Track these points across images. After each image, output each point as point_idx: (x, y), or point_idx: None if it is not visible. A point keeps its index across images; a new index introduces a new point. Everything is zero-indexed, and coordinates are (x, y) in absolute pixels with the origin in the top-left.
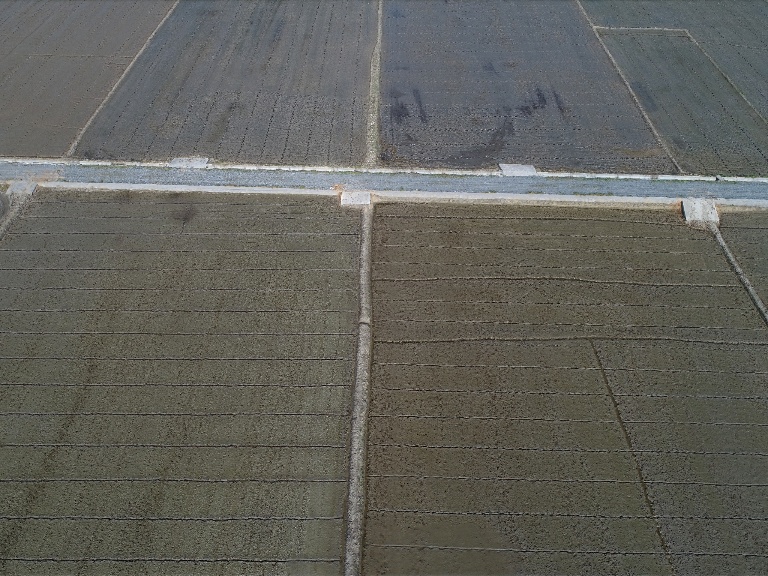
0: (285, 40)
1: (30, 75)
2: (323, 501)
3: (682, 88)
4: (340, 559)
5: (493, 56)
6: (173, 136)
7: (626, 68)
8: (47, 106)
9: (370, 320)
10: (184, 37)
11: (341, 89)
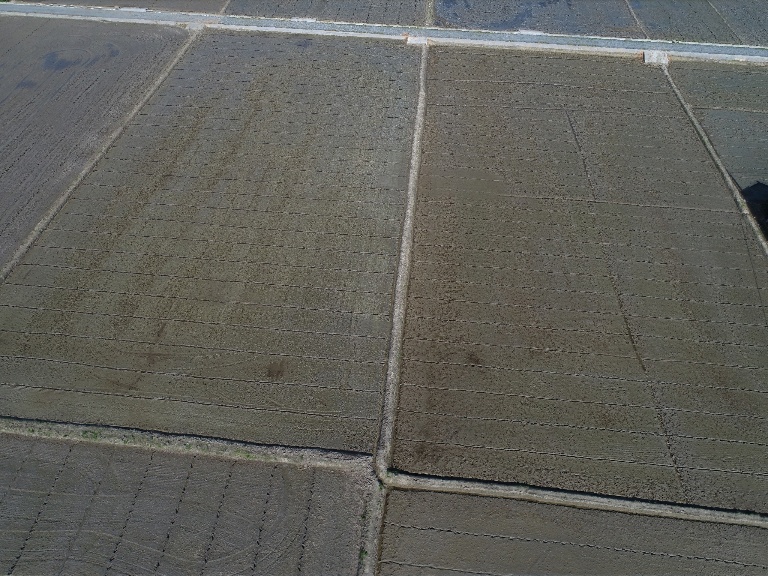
0: None
1: None
2: (397, 157)
3: None
4: (406, 176)
5: None
6: (290, 7)
7: None
8: None
9: (425, 95)
10: None
11: None
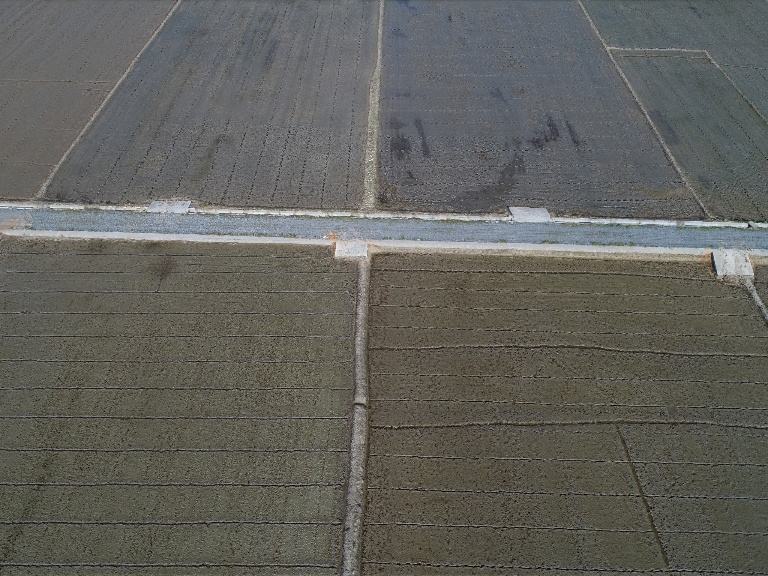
0: (278, 63)
1: (3, 103)
2: None
3: (705, 117)
4: None
5: (501, 81)
6: (154, 174)
7: (643, 94)
8: (19, 139)
9: (366, 400)
10: (171, 60)
11: (337, 119)
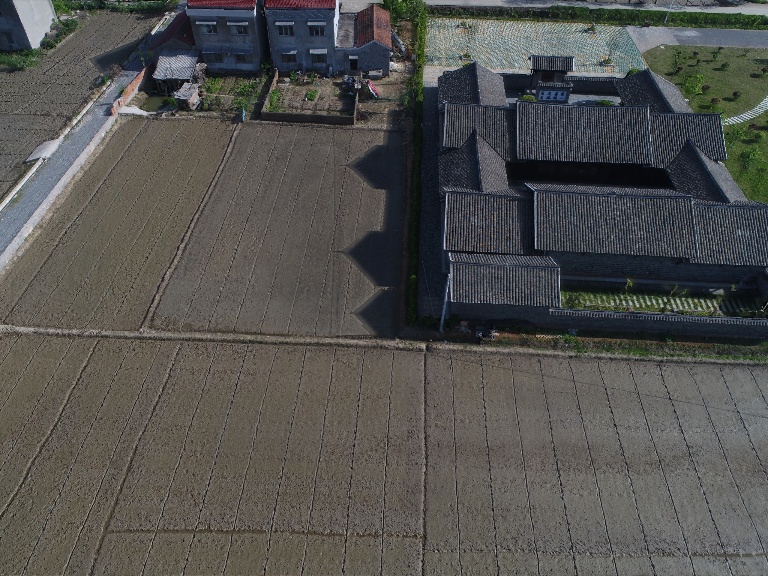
0: None
1: None
2: None
3: None
4: None
5: None
6: None
7: None
8: None
9: None
10: None
11: None
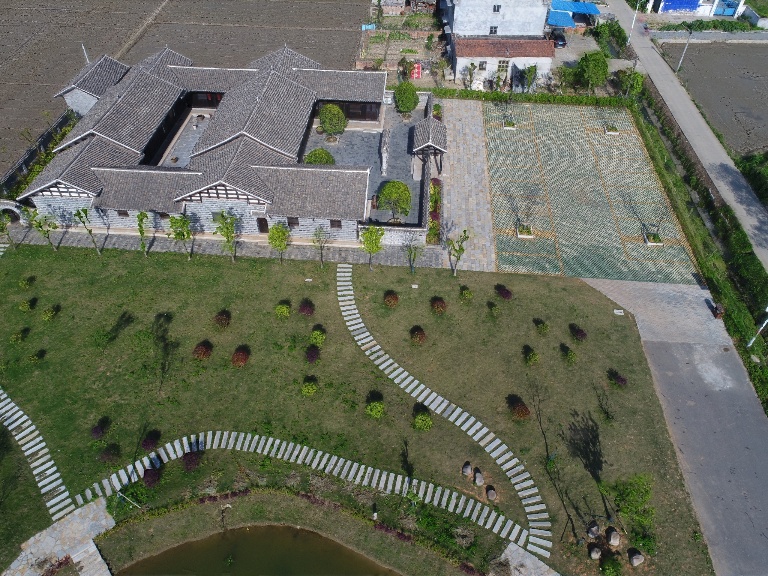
0: None
1: None
2: None
3: None
4: None
5: None
6: None
7: None
8: None
9: None
10: None
11: None
